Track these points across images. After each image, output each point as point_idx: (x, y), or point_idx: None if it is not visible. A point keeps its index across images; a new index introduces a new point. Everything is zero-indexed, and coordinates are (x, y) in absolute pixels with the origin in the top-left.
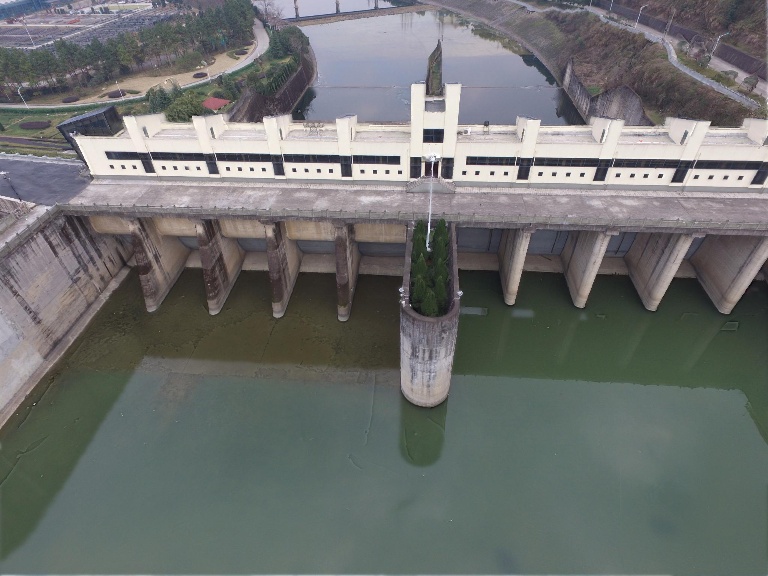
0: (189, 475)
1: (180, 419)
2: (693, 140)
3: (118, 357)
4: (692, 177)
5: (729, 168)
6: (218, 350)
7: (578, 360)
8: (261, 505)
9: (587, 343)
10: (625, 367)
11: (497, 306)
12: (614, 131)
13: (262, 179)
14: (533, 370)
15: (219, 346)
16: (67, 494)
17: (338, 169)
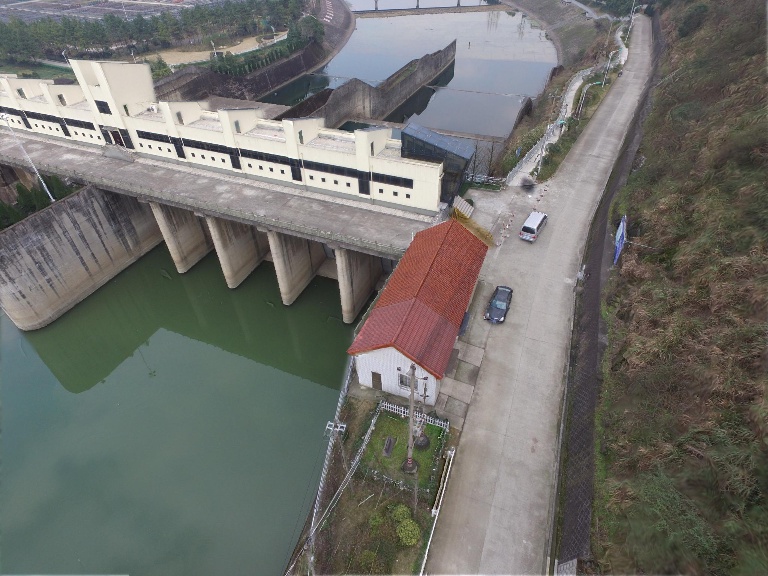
0: None
1: None
2: (289, 138)
3: None
4: (308, 177)
5: (334, 173)
6: None
7: (261, 343)
8: None
9: (263, 328)
10: (300, 361)
11: (169, 271)
12: (224, 120)
13: (23, 130)
14: (231, 344)
15: None
16: None
17: (61, 129)
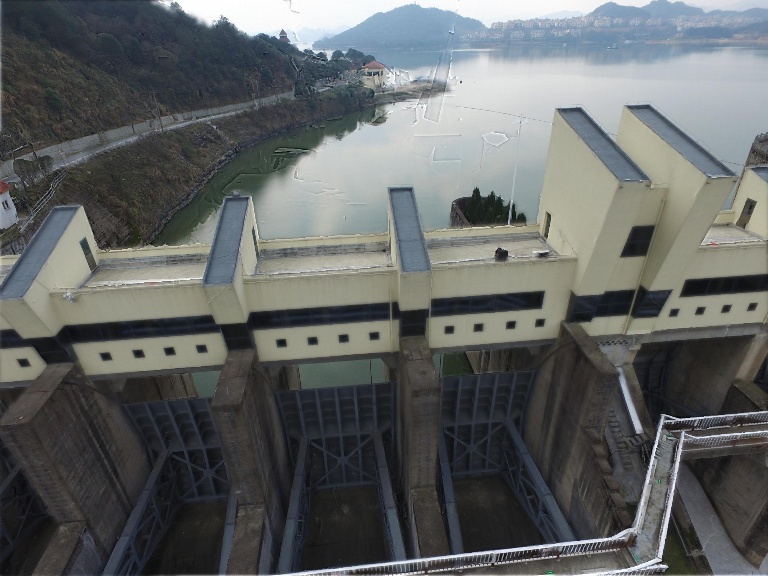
0: None
1: None
2: None
3: None
4: None
5: None
6: None
7: None
8: None
9: None
10: None
11: None
12: None
13: None
14: None
15: None
16: None
17: None
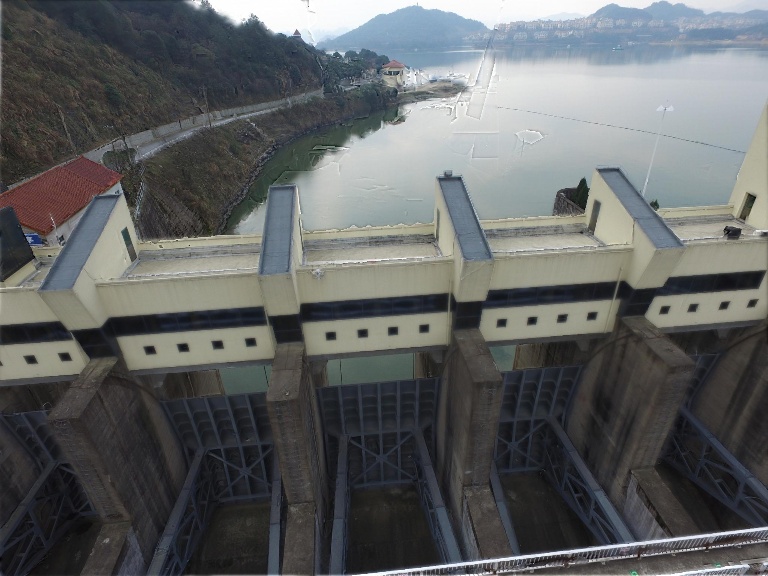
0: None
1: None
2: None
3: None
4: None
5: None
6: None
7: None
8: None
9: None
10: None
11: None
12: None
13: None
14: None
15: None
16: None
17: None
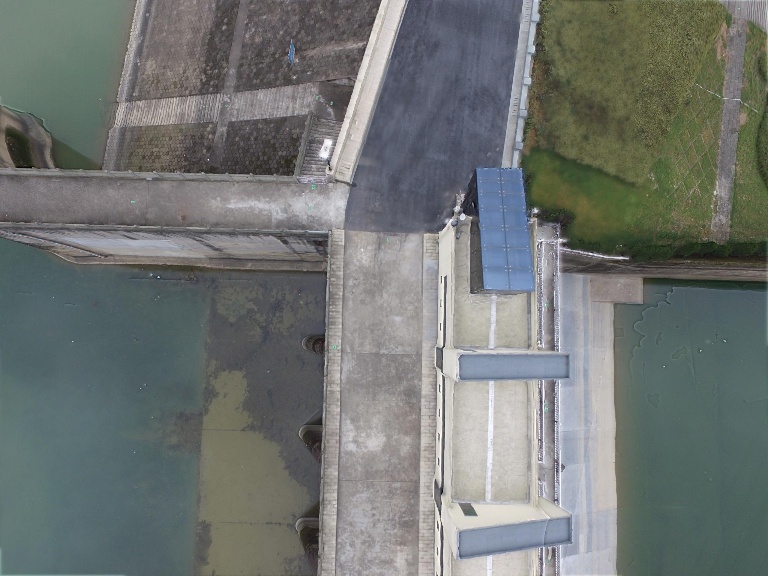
0: (75, 490)
1: (144, 450)
2: None
3: (225, 339)
4: None
5: None
6: (238, 462)
7: None
8: (52, 569)
9: None
10: None
11: None
12: None
13: None
14: None
15: (245, 461)
16: (55, 378)
17: None
